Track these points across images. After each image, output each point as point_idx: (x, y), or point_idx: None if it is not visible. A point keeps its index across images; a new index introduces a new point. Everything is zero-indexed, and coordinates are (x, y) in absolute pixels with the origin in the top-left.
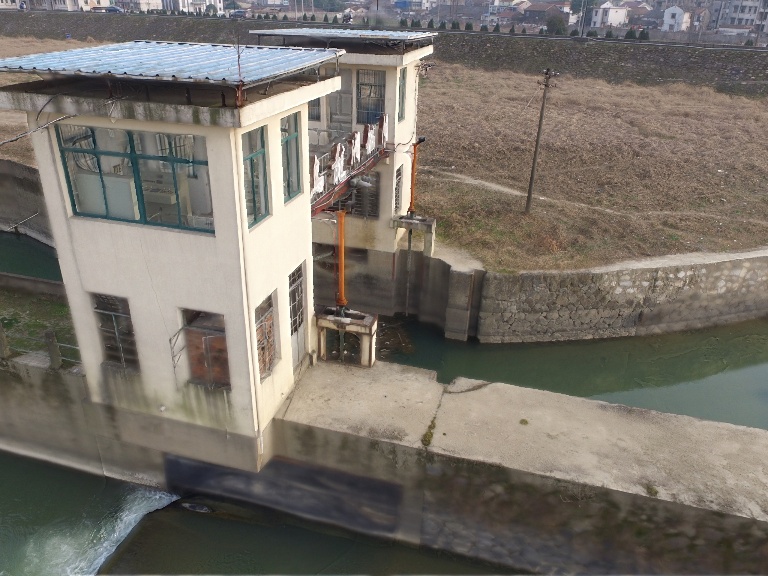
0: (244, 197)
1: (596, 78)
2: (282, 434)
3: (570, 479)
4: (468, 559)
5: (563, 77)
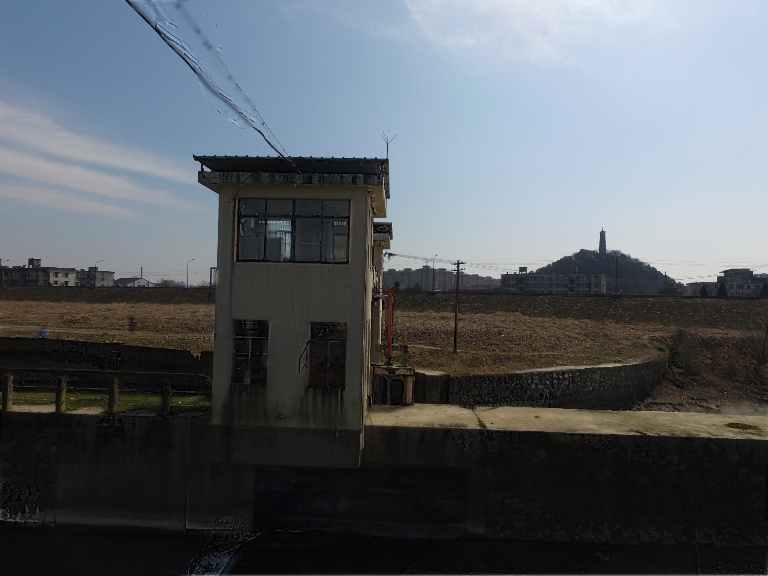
0: None
1: (448, 312)
2: (371, 438)
3: (590, 433)
4: (525, 534)
5: (428, 312)
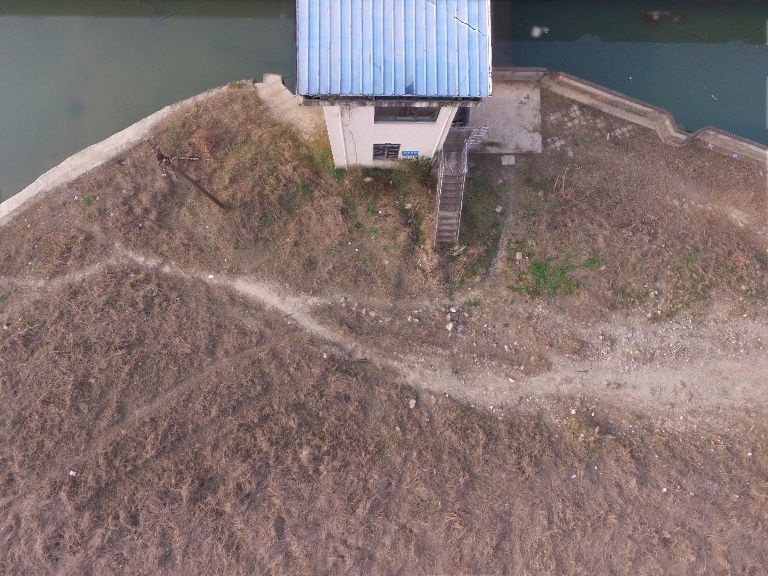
0: None
1: None
2: None
3: None
4: None
5: None
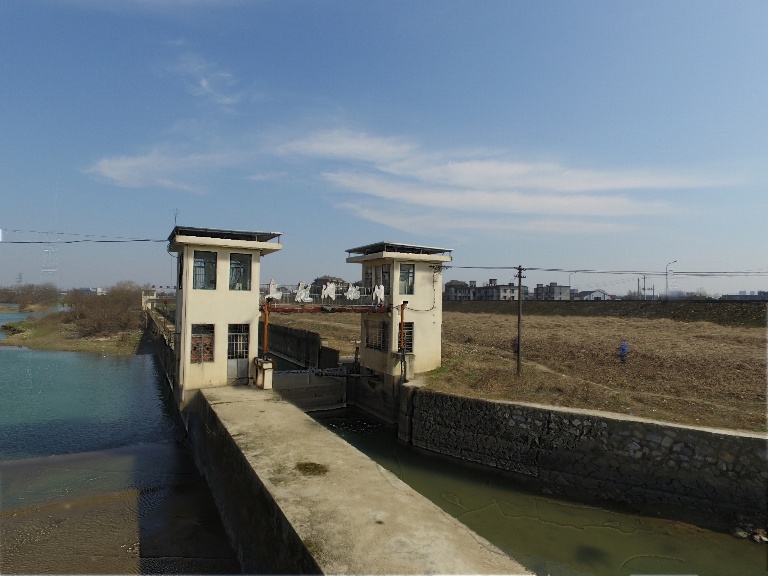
0: (192, 274)
1: None
2: (198, 397)
3: (224, 423)
4: None
5: None
